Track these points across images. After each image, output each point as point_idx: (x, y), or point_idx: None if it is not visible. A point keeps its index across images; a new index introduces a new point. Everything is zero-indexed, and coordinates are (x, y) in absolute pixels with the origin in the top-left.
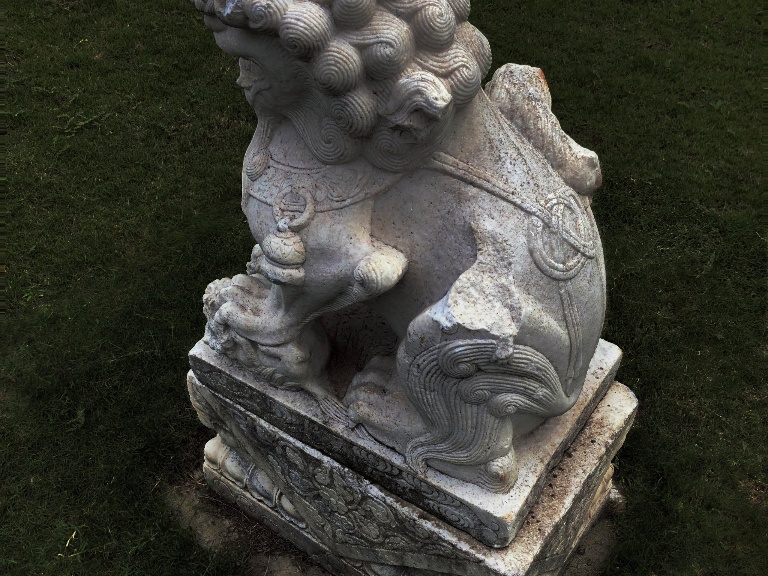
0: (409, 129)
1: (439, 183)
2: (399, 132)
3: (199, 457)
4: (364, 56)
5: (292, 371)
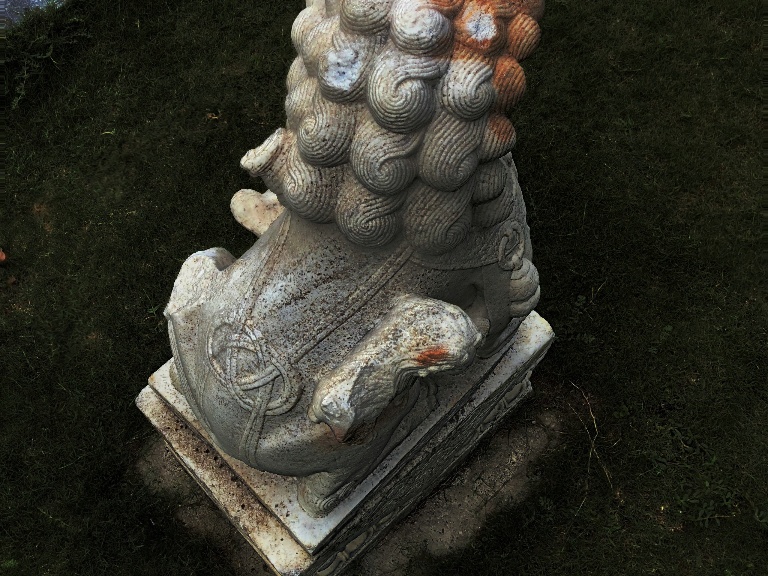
0: None
1: None
2: None
3: None
4: None
5: None
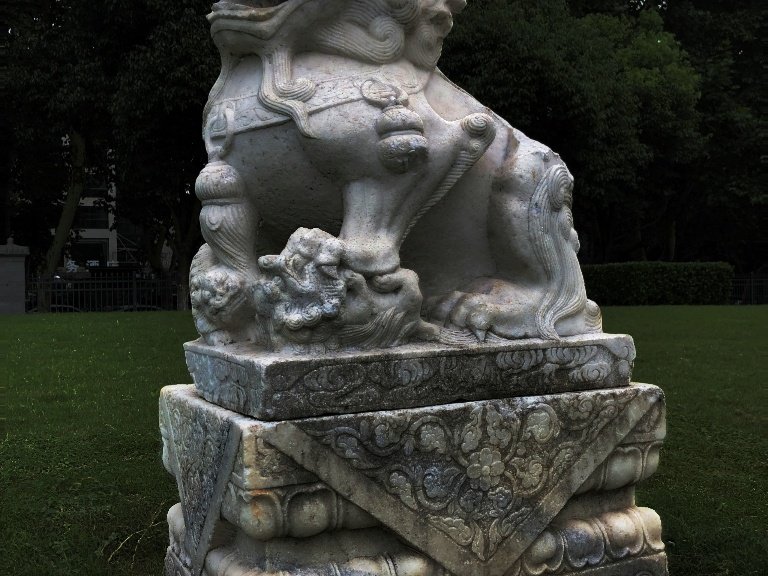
0: (444, 18)
1: (447, 85)
2: (433, 26)
3: None
4: None
5: (418, 294)
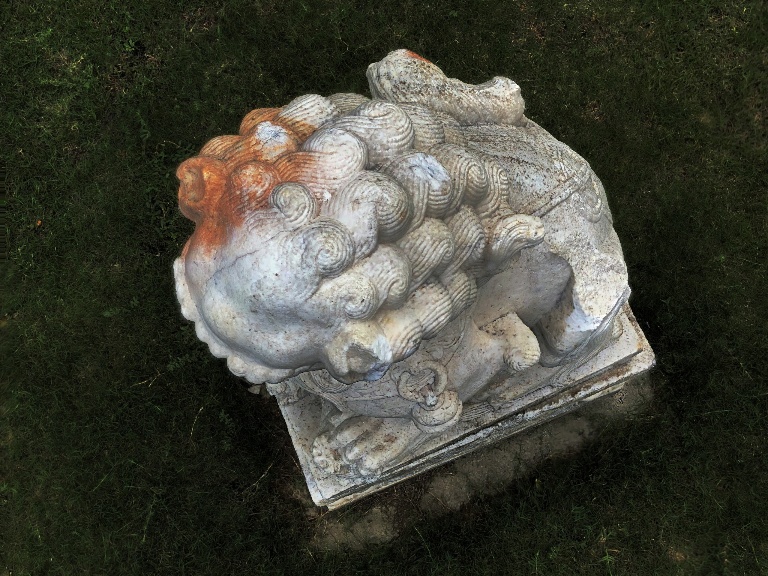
0: None
1: None
2: None
3: (296, 504)
4: (465, 267)
5: None
